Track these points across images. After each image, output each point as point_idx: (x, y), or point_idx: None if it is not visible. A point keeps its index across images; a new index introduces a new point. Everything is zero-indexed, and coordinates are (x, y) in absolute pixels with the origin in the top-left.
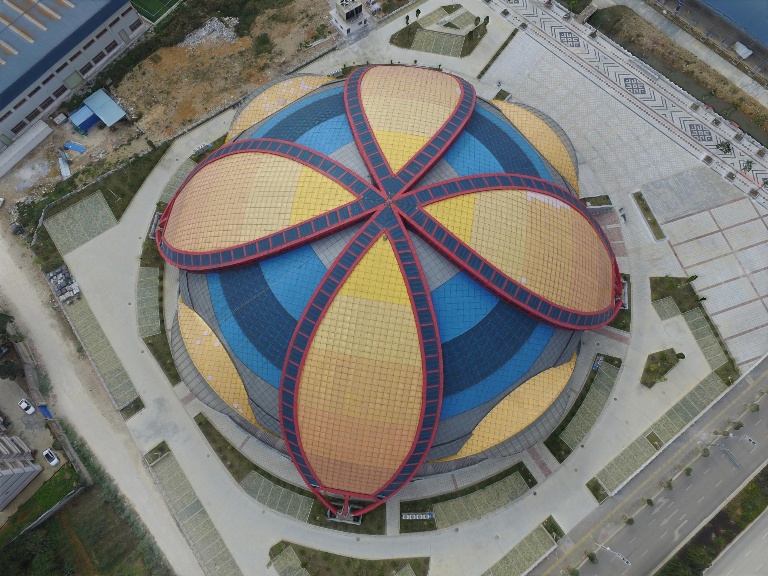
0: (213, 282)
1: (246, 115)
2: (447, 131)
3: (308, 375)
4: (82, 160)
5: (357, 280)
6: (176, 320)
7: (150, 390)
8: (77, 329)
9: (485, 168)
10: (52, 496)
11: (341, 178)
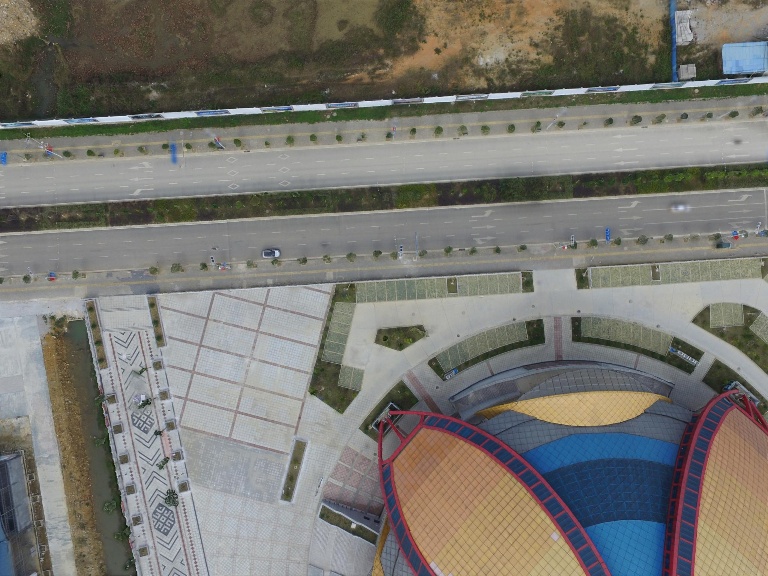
0: None
1: None
2: None
3: None
4: None
5: None
6: None
7: None
8: None
9: None
10: None
11: None
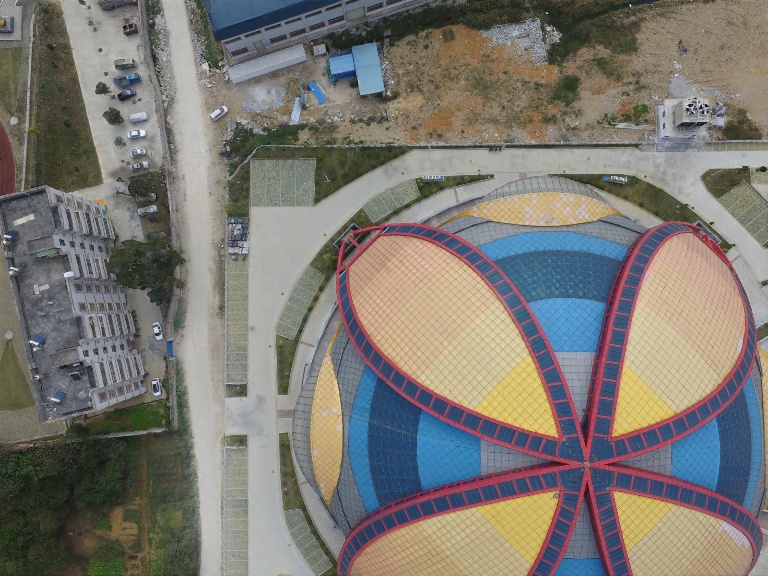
0: (369, 376)
1: (502, 205)
2: (697, 415)
3: (400, 536)
4: (316, 112)
5: (502, 511)
6: (316, 372)
7: (258, 384)
8: (228, 287)
9: (702, 468)
10: (143, 419)
11: (557, 403)
